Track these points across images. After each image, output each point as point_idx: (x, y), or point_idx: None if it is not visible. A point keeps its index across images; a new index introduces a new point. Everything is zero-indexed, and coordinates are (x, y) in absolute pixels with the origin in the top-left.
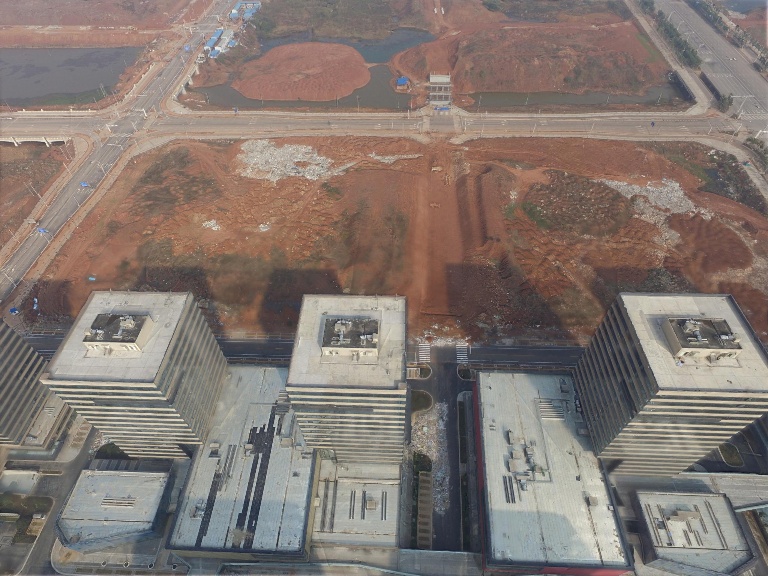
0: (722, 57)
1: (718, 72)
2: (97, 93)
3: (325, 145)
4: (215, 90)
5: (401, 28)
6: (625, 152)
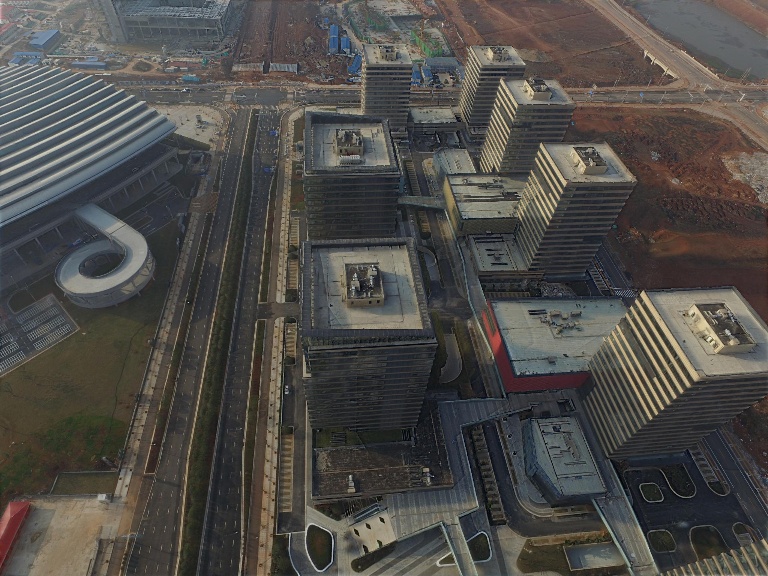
0: None
1: None
2: (742, 74)
3: None
4: None
5: None
6: None
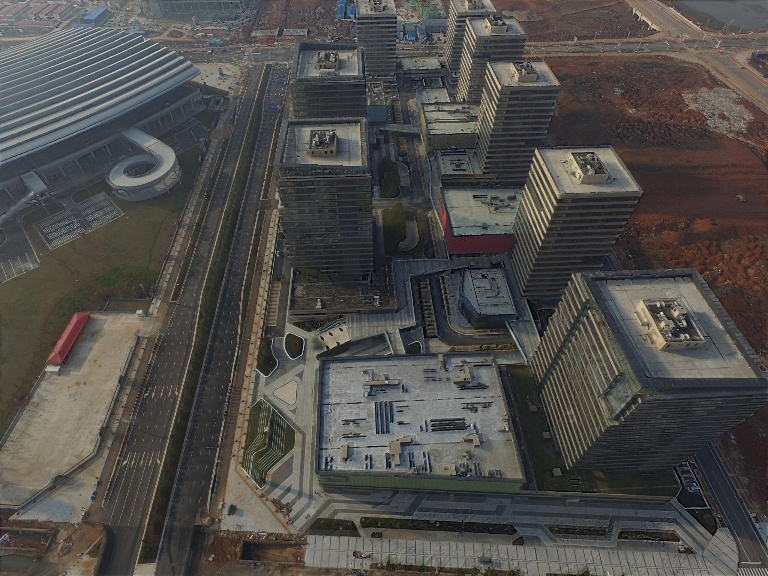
0: None
1: None
2: None
3: None
4: None
5: None
6: None
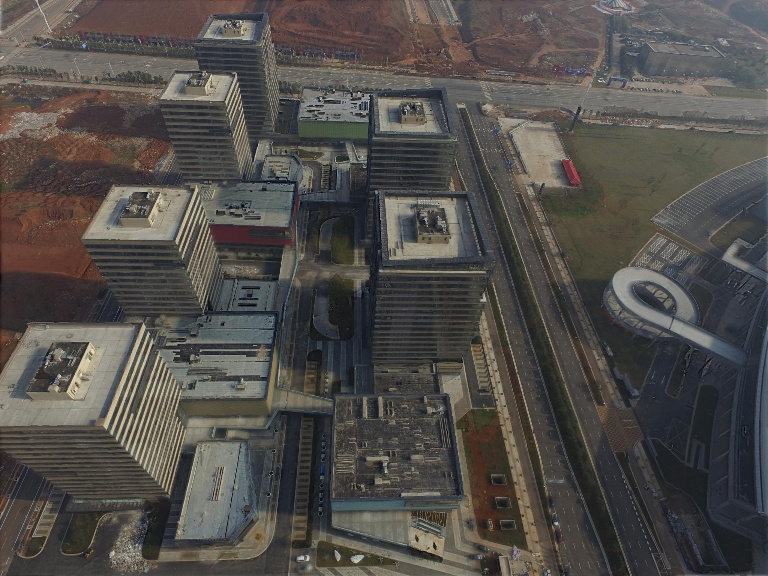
0: None
1: None
2: None
3: None
4: None
5: None
6: None
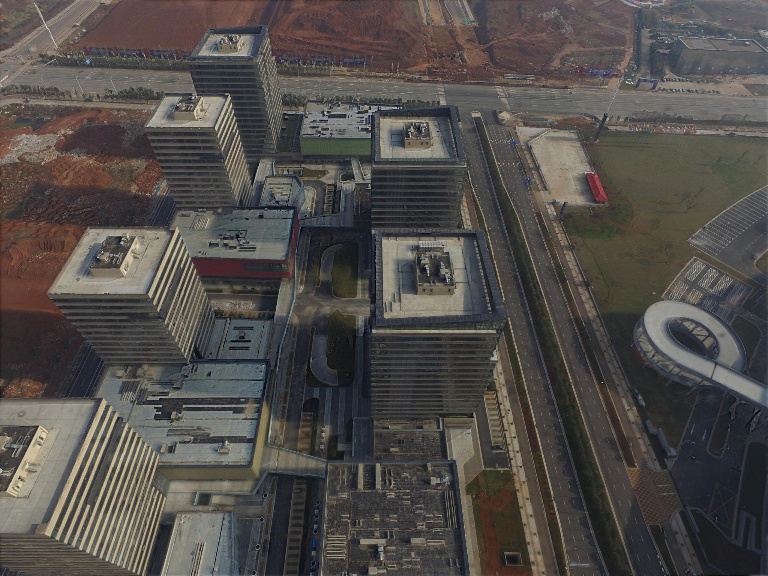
0: None
1: None
2: None
3: None
4: None
5: None
6: None
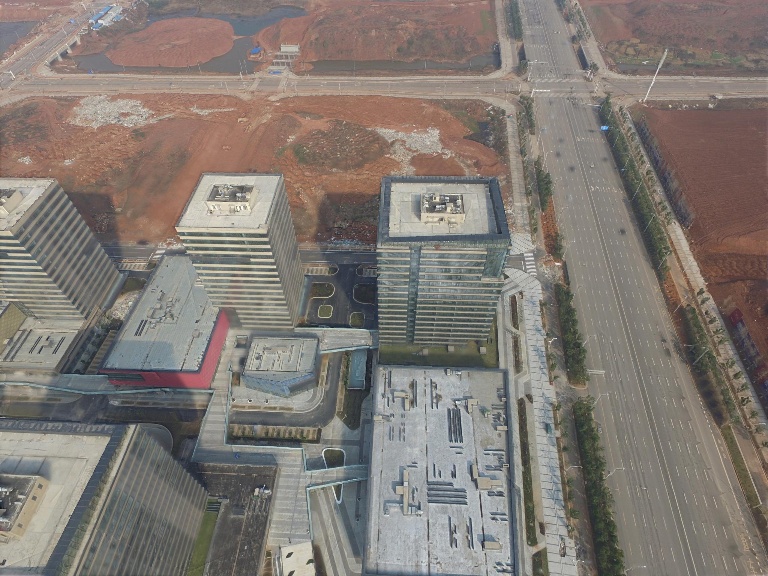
0: (548, 31)
1: (536, 43)
2: None
3: (153, 100)
4: (90, 58)
5: (281, 6)
6: (410, 107)
